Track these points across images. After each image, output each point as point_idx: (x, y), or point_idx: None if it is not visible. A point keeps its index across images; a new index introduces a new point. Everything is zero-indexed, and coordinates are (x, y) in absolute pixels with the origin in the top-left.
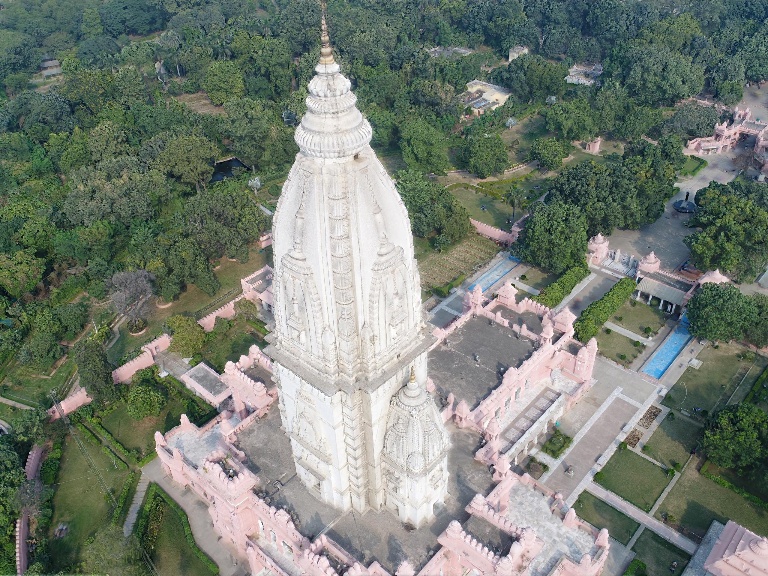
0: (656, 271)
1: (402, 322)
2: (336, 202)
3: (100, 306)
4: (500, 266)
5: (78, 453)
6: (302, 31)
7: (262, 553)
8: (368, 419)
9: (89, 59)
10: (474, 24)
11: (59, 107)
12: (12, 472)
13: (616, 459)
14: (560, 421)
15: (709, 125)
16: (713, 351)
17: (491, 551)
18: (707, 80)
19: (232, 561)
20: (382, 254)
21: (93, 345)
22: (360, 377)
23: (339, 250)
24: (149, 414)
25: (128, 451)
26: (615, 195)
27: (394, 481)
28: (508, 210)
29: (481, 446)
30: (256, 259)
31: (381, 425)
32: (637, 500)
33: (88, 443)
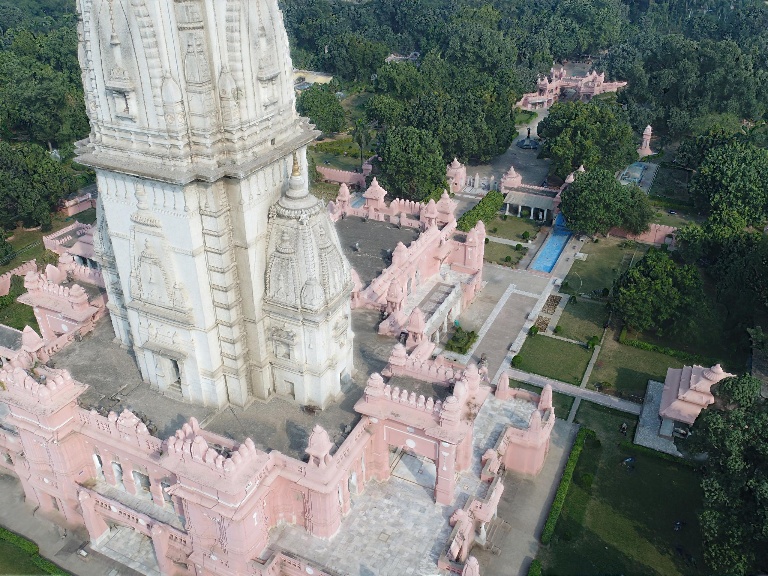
0: (519, 186)
1: (273, 83)
2: None
3: None
4: (356, 204)
5: None
6: None
7: (102, 498)
8: (240, 237)
9: None
10: None
11: None
12: None
13: (529, 345)
14: (459, 321)
15: (532, 81)
16: (594, 245)
17: (430, 397)
18: (518, 58)
19: (58, 534)
20: None
21: None
22: (223, 161)
23: None
24: None
25: None
26: (464, 120)
27: (285, 339)
28: (353, 162)
29: (383, 320)
30: (62, 226)
31: (259, 252)
32: (564, 376)
33: None
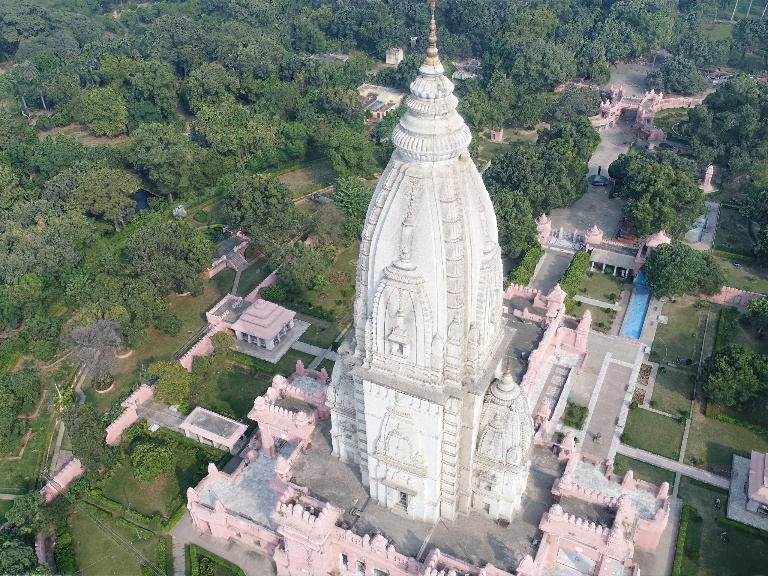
0: (602, 242)
1: None
2: (450, 205)
3: (49, 368)
4: None
5: (88, 533)
6: (173, 50)
7: None
8: (468, 422)
9: None
10: (344, 30)
11: None
12: (37, 570)
13: (632, 419)
14: (570, 394)
15: (595, 104)
16: (673, 306)
17: (600, 525)
18: None
19: None
20: (488, 252)
21: (87, 409)
22: (465, 380)
23: (456, 253)
24: (161, 472)
25: (147, 517)
26: (549, 177)
27: (489, 480)
28: None
29: (535, 430)
30: (208, 290)
31: (477, 426)
32: (664, 452)
33: None
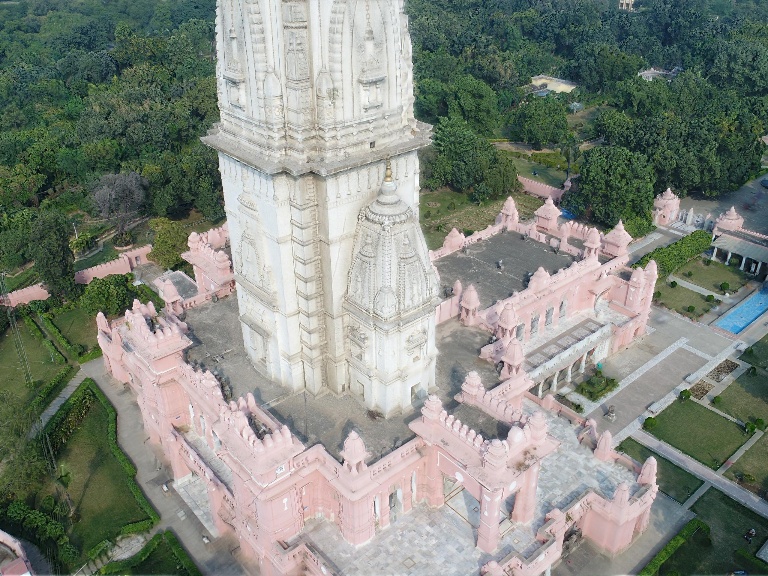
0: (737, 230)
1: (378, 86)
2: None
3: (92, 223)
4: None
5: None
6: None
7: (186, 445)
8: (325, 233)
9: (147, 33)
10: (546, 32)
11: (105, 65)
12: None
13: (675, 409)
14: (603, 364)
15: None
16: None
17: (479, 434)
18: None
19: (155, 465)
20: None
21: (52, 220)
22: (314, 158)
23: None
24: (104, 309)
25: None
26: (690, 147)
27: (358, 339)
28: (563, 177)
29: (490, 344)
30: None
31: (344, 250)
32: (701, 455)
33: (31, 336)
